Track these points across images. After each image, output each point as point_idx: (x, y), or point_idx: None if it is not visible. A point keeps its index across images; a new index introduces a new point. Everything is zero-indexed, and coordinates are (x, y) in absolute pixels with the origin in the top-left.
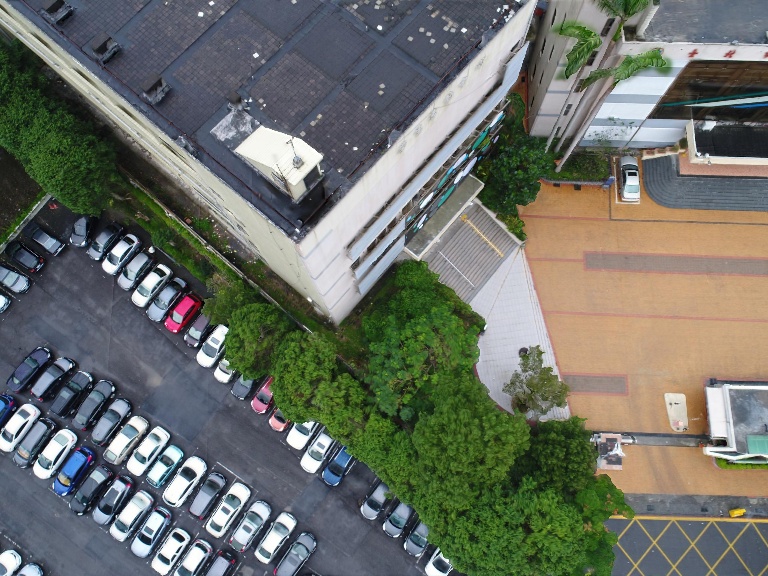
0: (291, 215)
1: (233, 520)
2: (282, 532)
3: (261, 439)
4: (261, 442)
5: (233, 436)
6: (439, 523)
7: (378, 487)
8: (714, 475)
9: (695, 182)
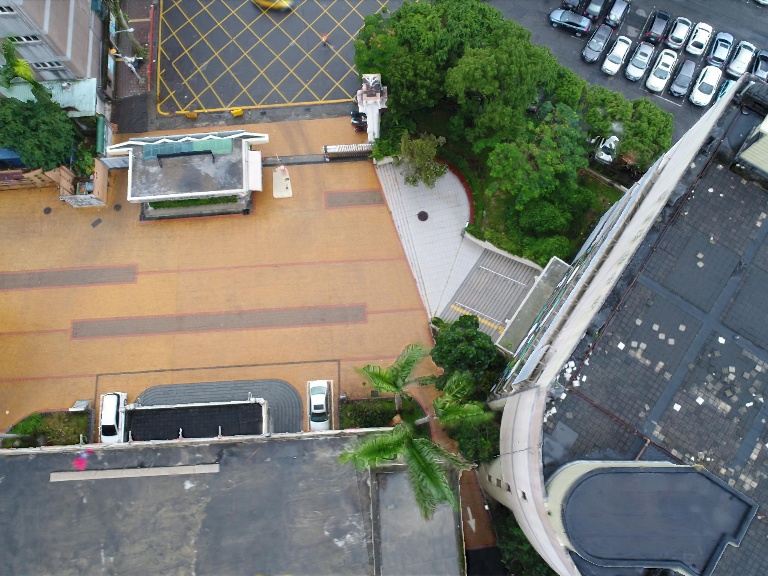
0: (756, 117)
1: None
2: (613, 58)
3: None
4: None
5: None
6: None
7: None
8: None
9: None
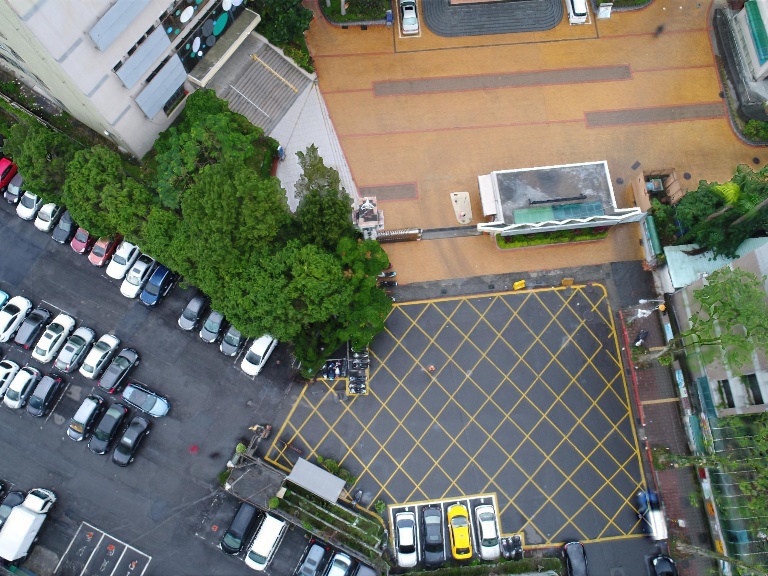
0: None
1: (59, 347)
2: (104, 349)
3: (83, 276)
4: (84, 279)
5: (57, 276)
6: (217, 288)
7: (192, 300)
8: (498, 257)
9: (465, 10)
